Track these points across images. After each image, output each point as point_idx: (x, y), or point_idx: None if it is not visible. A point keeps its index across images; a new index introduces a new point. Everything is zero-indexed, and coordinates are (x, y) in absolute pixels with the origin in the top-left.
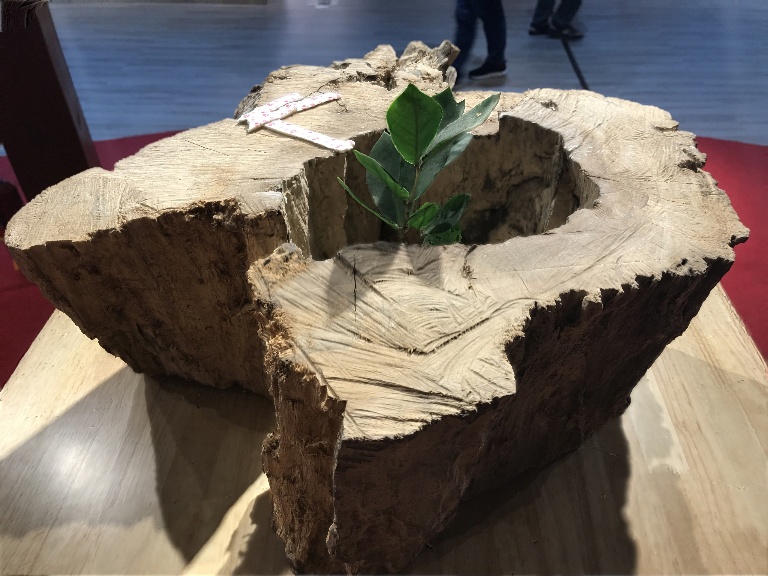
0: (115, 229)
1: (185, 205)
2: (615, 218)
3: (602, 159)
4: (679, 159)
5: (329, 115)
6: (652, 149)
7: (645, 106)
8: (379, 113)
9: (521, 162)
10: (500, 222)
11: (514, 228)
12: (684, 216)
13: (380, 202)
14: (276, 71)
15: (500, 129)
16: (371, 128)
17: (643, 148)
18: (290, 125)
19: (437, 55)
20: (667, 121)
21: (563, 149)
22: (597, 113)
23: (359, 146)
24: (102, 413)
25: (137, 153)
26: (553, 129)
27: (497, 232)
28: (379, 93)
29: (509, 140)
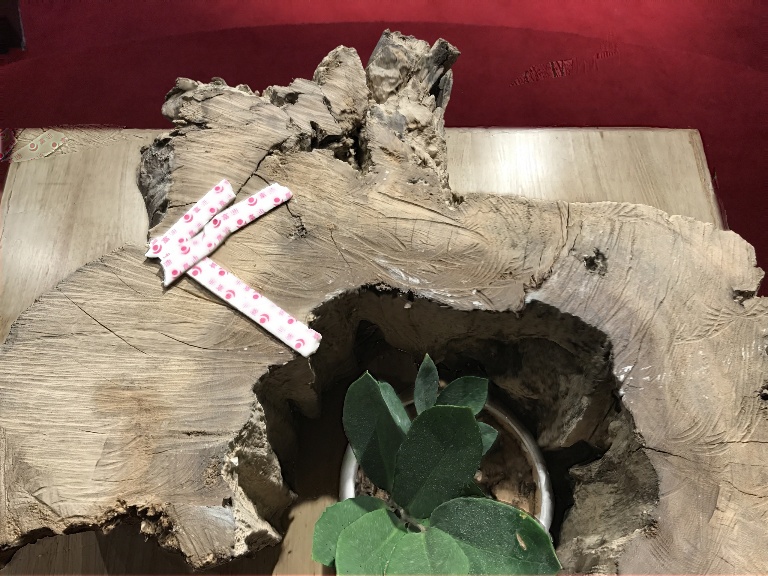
0: (8, 546)
1: (98, 511)
2: (677, 557)
3: (663, 399)
4: (761, 378)
5: (278, 243)
6: (728, 355)
7: (723, 232)
8: (351, 241)
9: (548, 336)
10: (510, 370)
11: (528, 387)
12: (761, 531)
13: (364, 459)
14: (188, 103)
15: (525, 311)
16: (342, 285)
17: (716, 354)
18: (224, 276)
19: (428, 67)
20: (750, 272)
21: (612, 373)
22: (659, 270)
23: (326, 308)
24: (49, 561)
25: (8, 337)
26: (600, 327)
27: (505, 381)
28: (348, 186)
29: (536, 322)
